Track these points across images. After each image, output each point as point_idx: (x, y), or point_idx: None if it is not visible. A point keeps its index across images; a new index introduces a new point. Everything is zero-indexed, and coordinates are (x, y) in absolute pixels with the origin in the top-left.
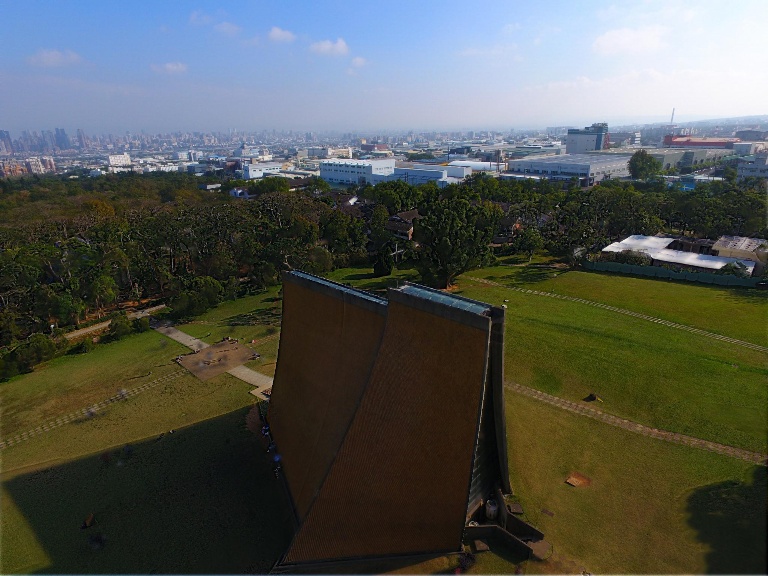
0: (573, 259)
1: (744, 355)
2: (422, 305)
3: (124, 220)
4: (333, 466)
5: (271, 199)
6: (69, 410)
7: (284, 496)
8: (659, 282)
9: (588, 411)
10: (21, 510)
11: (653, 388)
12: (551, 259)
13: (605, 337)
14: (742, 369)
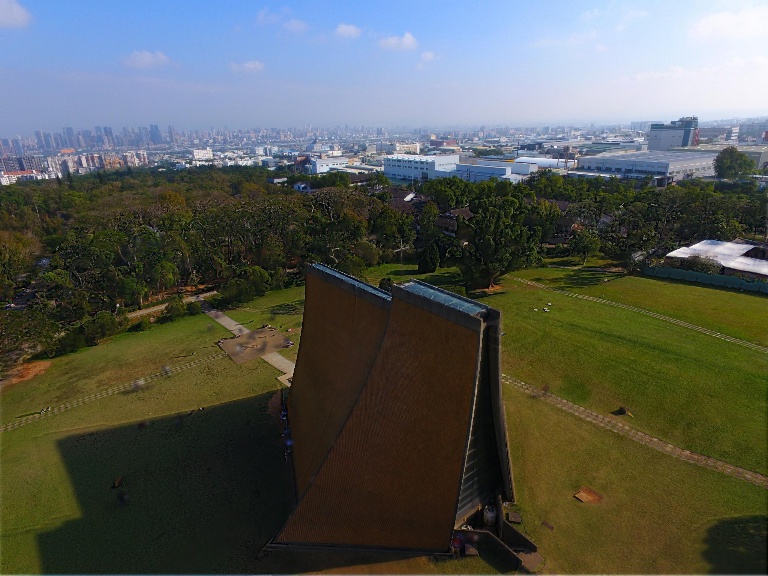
0: (631, 263)
1: None
2: (421, 303)
3: (188, 211)
4: (330, 455)
5: (324, 193)
6: (120, 382)
7: (289, 479)
8: (727, 292)
9: (614, 425)
10: (66, 466)
11: (694, 407)
12: (608, 263)
13: (650, 348)
14: None
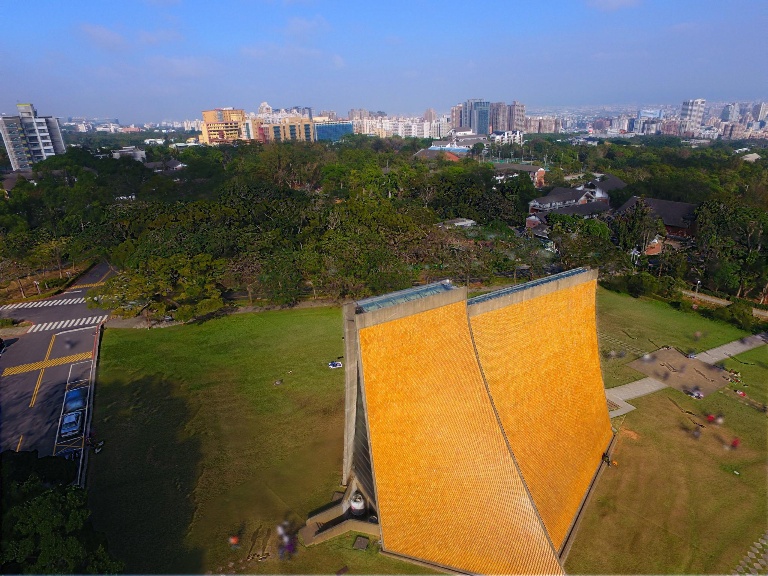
0: None
1: None
2: None
3: None
4: None
5: None
6: None
7: None
8: None
9: None
10: None
11: None
12: None
13: None
14: None
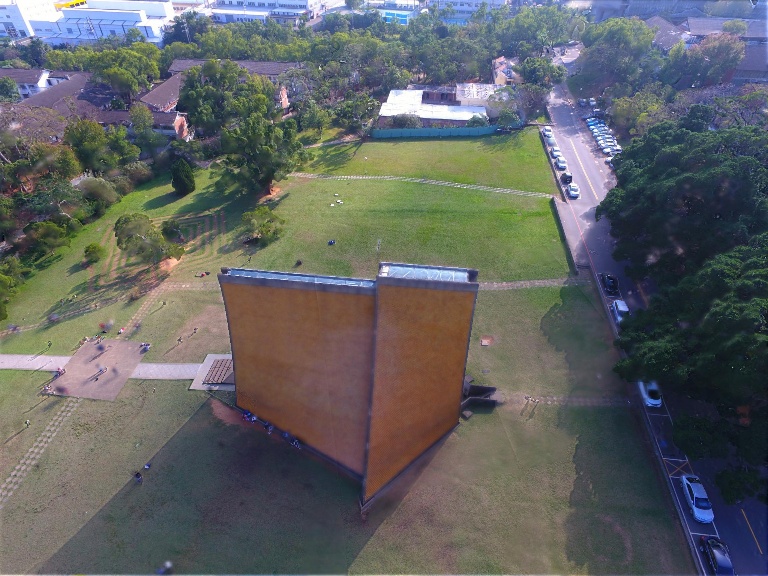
0: (362, 131)
1: (519, 203)
2: (415, 284)
3: None
4: (371, 422)
5: None
6: None
7: (319, 459)
8: (435, 142)
9: None
10: None
11: (487, 250)
12: (338, 131)
13: (434, 213)
14: (524, 216)
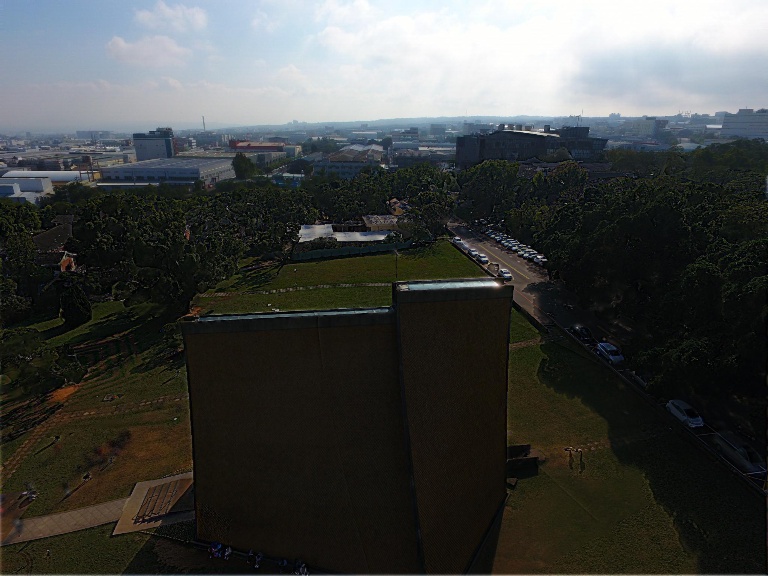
0: (282, 254)
1: None
2: (443, 296)
3: None
4: (418, 496)
5: None
6: None
7: None
8: (358, 258)
9: None
10: None
11: None
12: (254, 259)
13: None
14: None
